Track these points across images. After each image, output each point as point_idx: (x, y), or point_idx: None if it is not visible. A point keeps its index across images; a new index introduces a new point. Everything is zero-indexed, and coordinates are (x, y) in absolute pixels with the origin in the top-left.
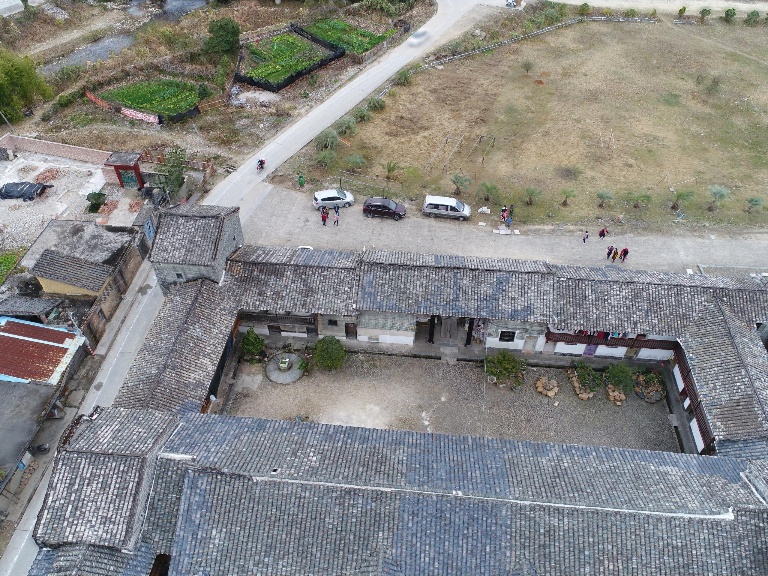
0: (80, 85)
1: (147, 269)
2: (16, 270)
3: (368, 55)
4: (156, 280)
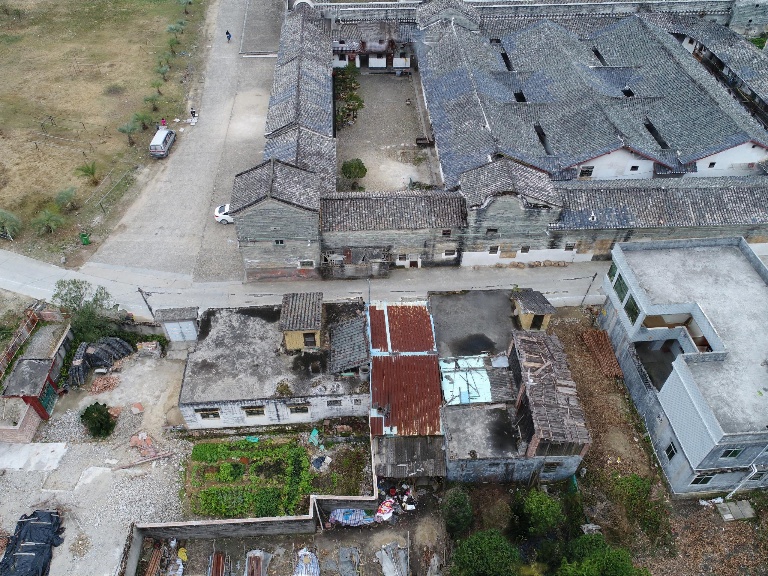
0: None
1: None
2: (284, 394)
3: None
4: None
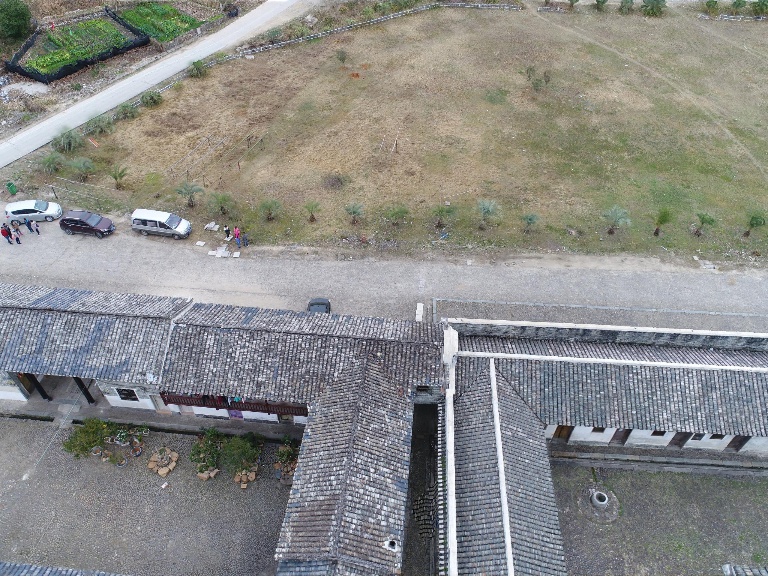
0: None
1: None
2: None
3: (171, 43)
4: None
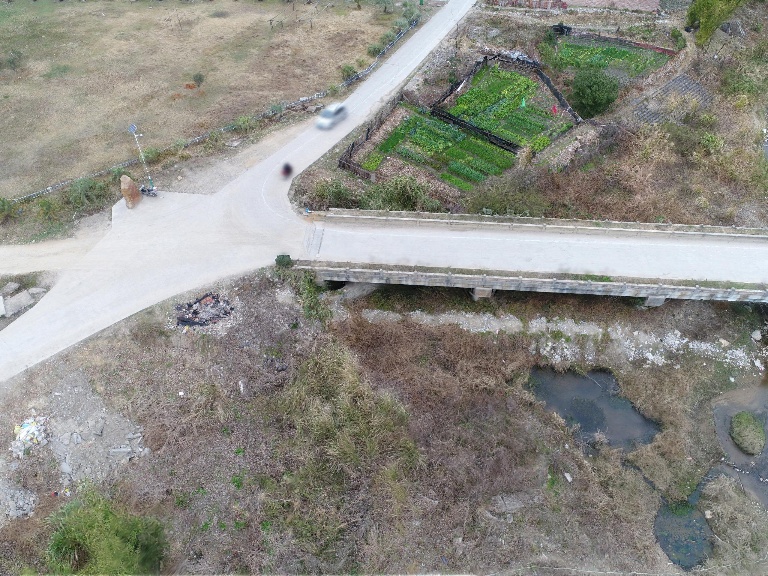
0: (689, 53)
1: None
2: None
3: None
4: None
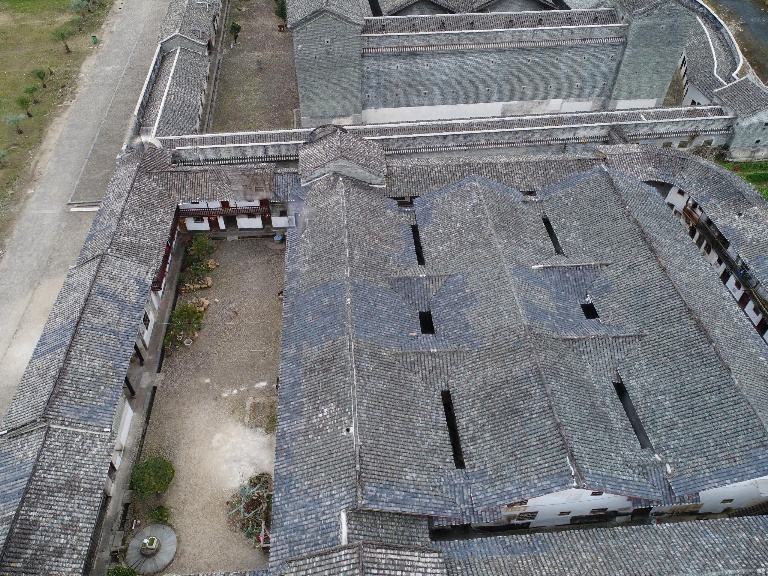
0: None
1: None
2: None
3: None
4: None
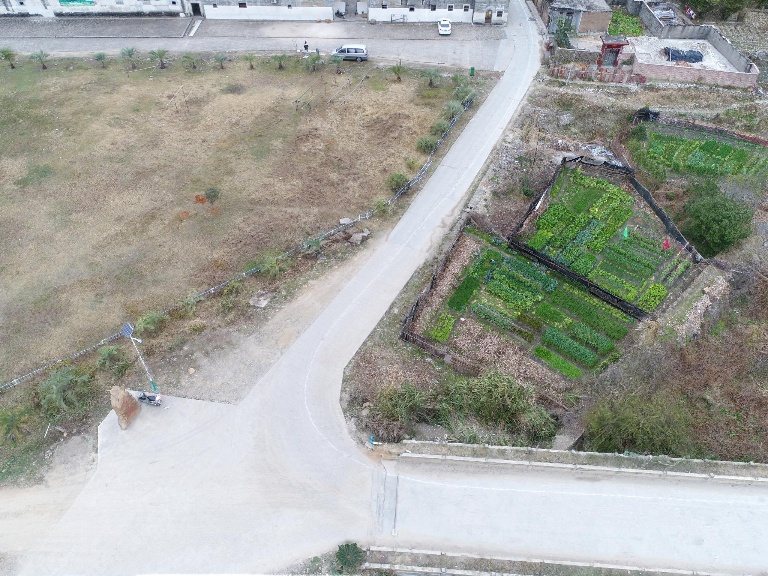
0: None
1: (540, 26)
2: None
3: None
4: (529, 22)
